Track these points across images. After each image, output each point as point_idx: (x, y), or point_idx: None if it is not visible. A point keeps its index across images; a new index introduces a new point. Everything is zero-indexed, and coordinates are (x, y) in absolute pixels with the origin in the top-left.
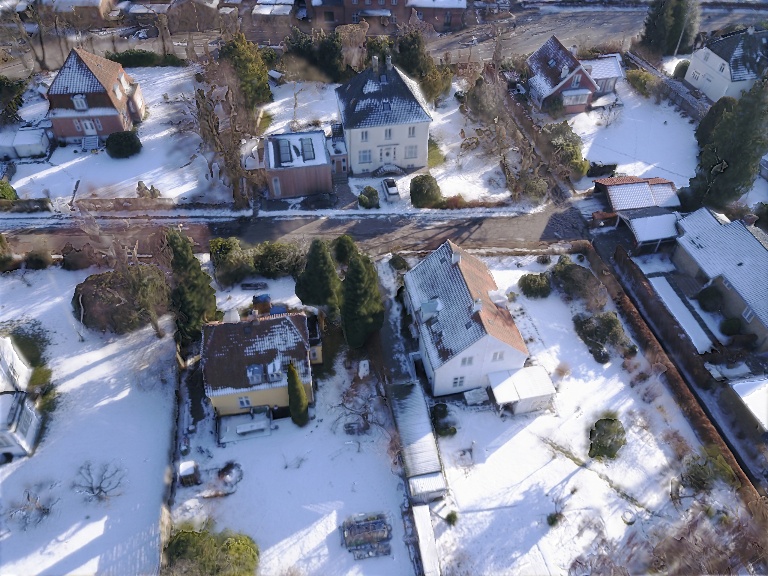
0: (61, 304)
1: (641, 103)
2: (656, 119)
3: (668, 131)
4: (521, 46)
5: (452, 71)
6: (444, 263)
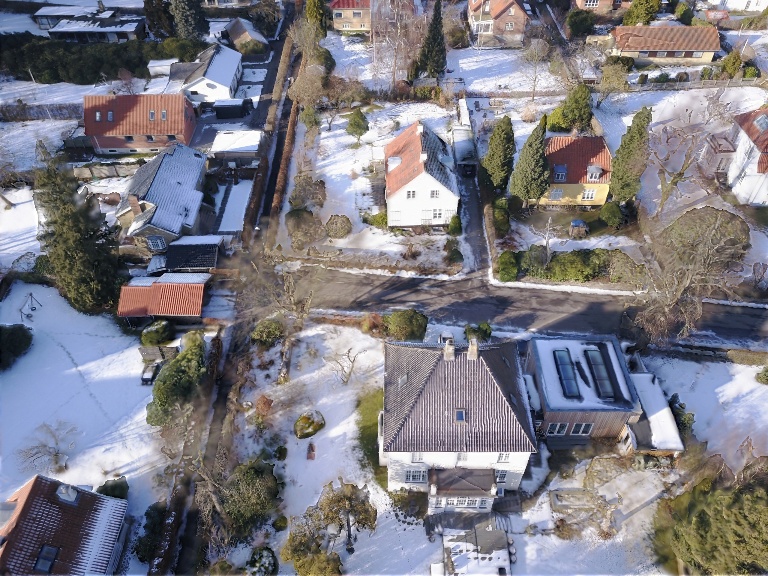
0: (765, 252)
1: None
2: None
3: None
4: None
5: None
6: (431, 168)
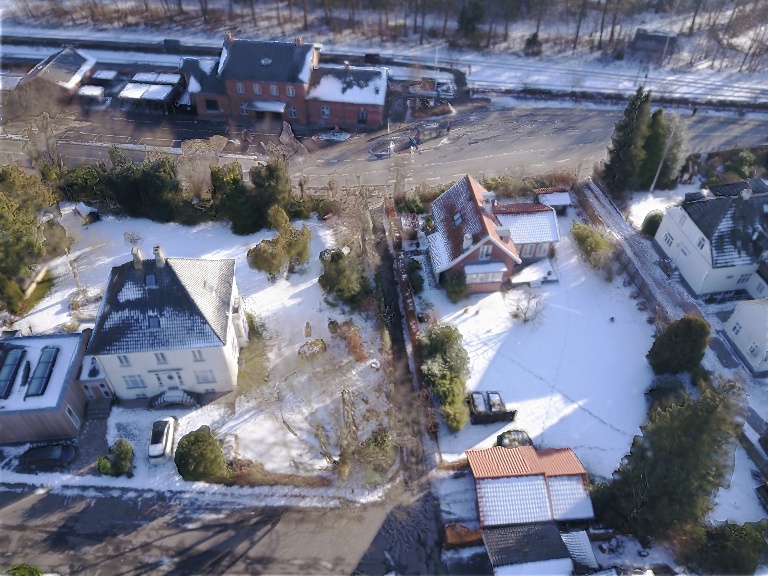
0: None
1: (585, 278)
2: (600, 310)
3: (613, 335)
4: (450, 161)
5: (332, 210)
6: None
